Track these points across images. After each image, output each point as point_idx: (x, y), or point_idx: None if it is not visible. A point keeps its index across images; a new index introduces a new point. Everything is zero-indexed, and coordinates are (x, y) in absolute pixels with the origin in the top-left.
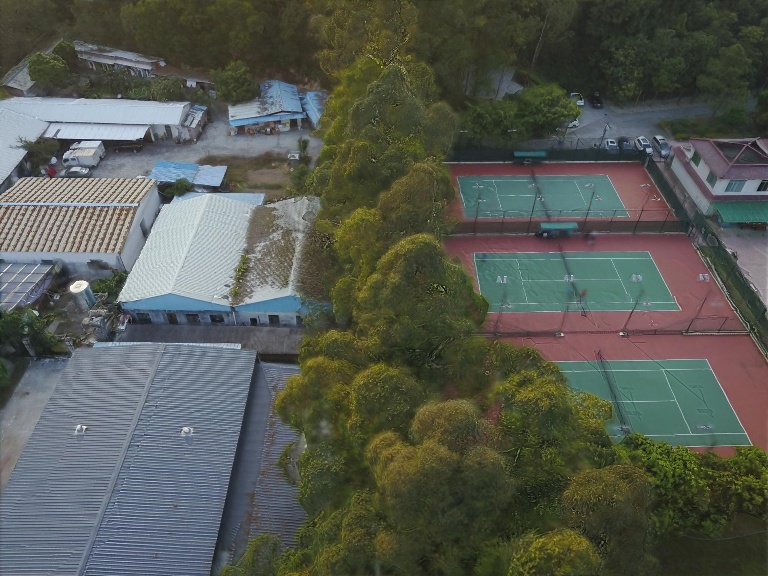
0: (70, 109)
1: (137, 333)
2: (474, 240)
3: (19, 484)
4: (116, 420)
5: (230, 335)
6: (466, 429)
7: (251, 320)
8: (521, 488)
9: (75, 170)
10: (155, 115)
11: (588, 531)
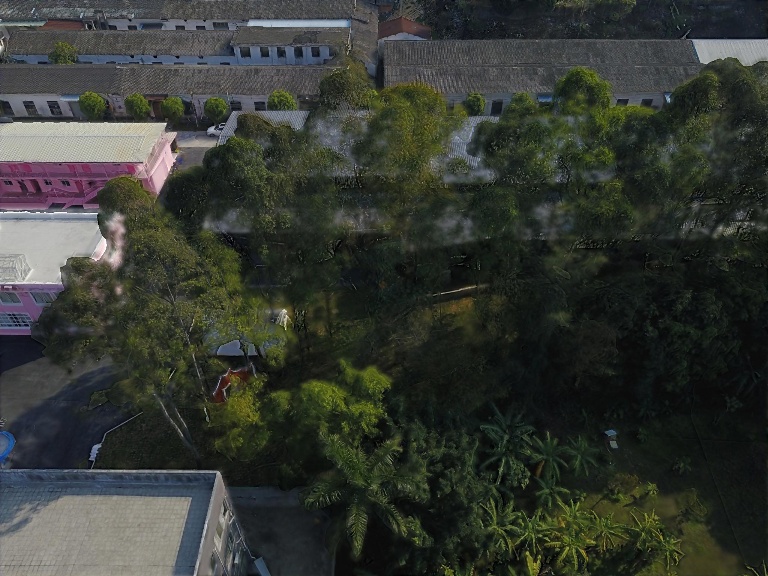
0: None
1: None
2: None
3: None
4: None
5: None
6: (756, 69)
7: None
8: None
9: None
10: None
11: (722, 88)
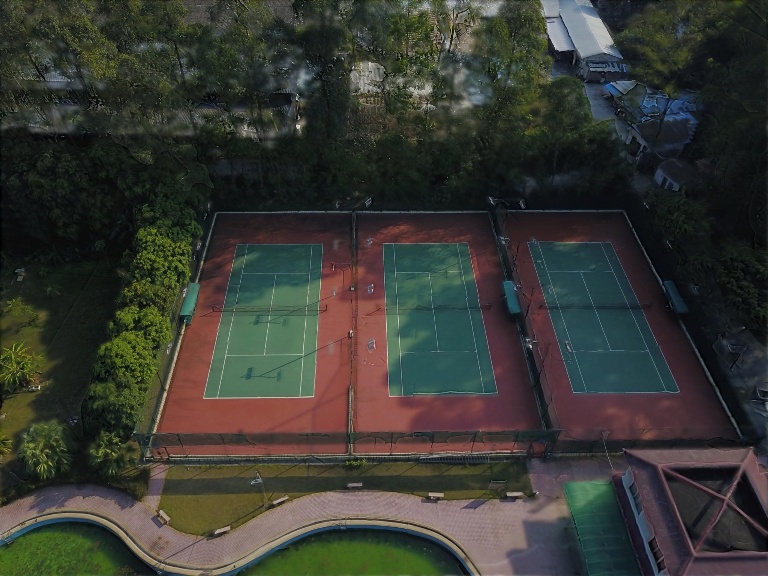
0: (577, 16)
1: None
2: (489, 244)
3: None
4: None
5: None
6: None
7: None
8: None
9: None
10: (587, 46)
11: None
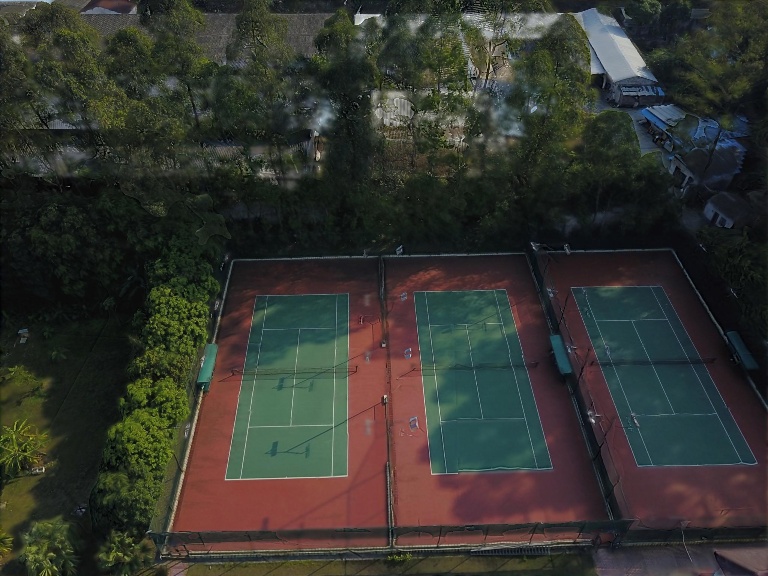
0: (604, 37)
1: None
2: (529, 291)
3: None
4: None
5: None
6: None
7: None
8: (19, 24)
9: None
10: (618, 69)
11: None
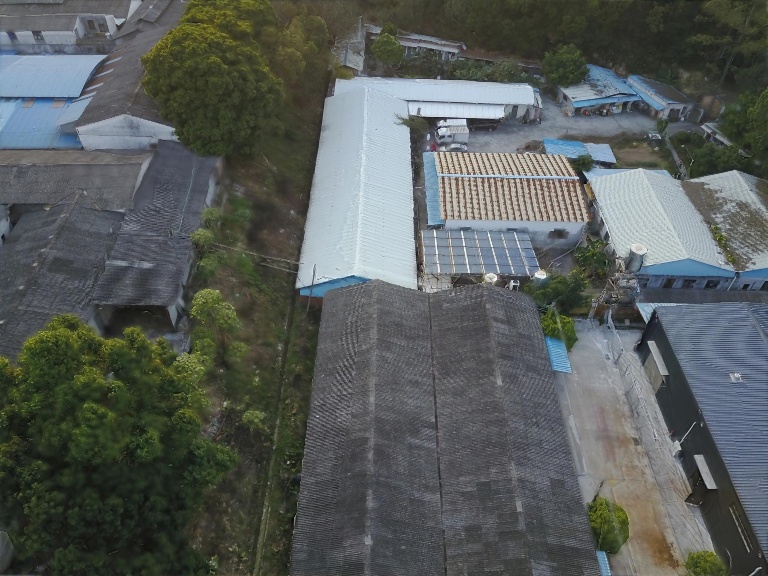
0: (423, 88)
1: (653, 296)
2: None
3: (721, 425)
4: (765, 369)
5: (742, 299)
6: None
7: (744, 286)
8: None
9: (457, 146)
10: (509, 95)
11: None
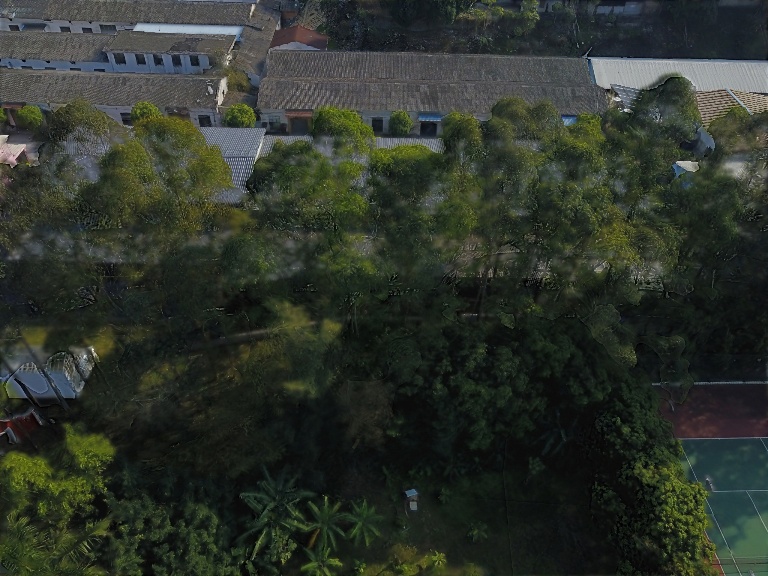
0: None
1: None
2: None
3: None
4: None
5: None
6: (539, 111)
7: None
8: None
9: None
10: None
11: (485, 134)
